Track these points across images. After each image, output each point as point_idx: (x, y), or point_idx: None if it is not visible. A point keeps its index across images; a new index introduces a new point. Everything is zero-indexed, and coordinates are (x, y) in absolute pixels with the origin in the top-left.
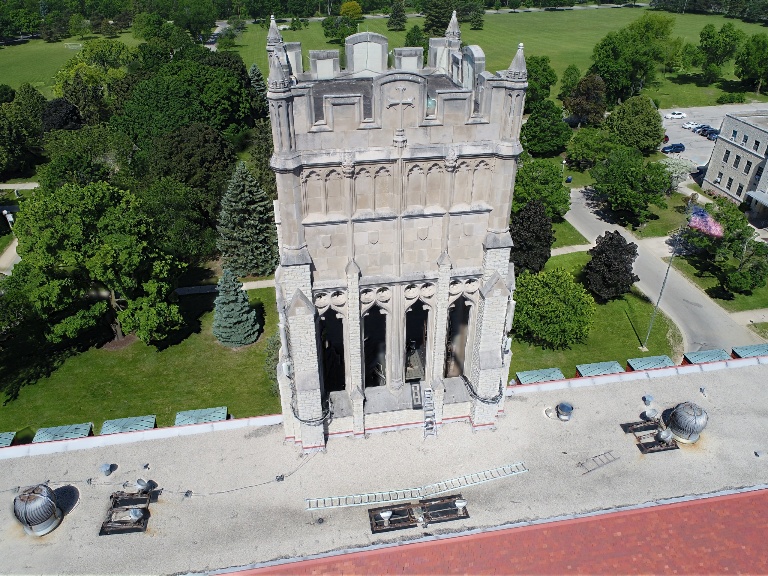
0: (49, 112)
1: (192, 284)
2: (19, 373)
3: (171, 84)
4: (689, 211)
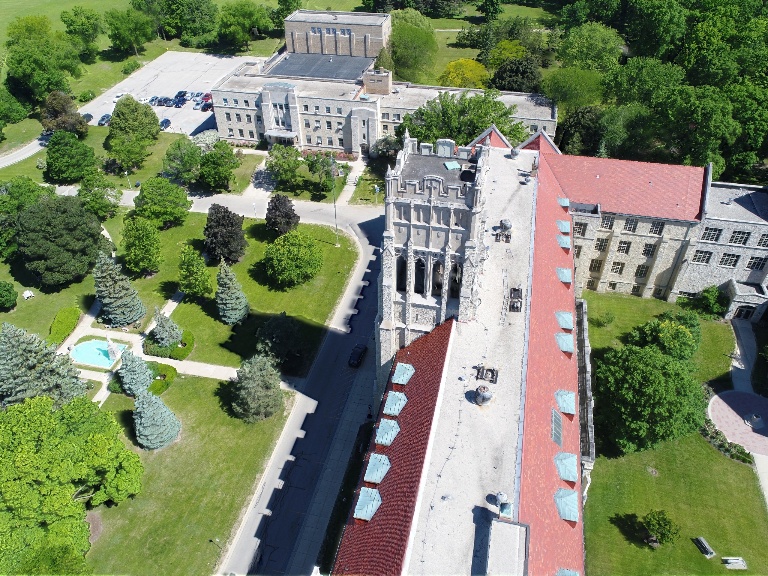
0: None
1: None
2: None
3: None
4: (241, 162)
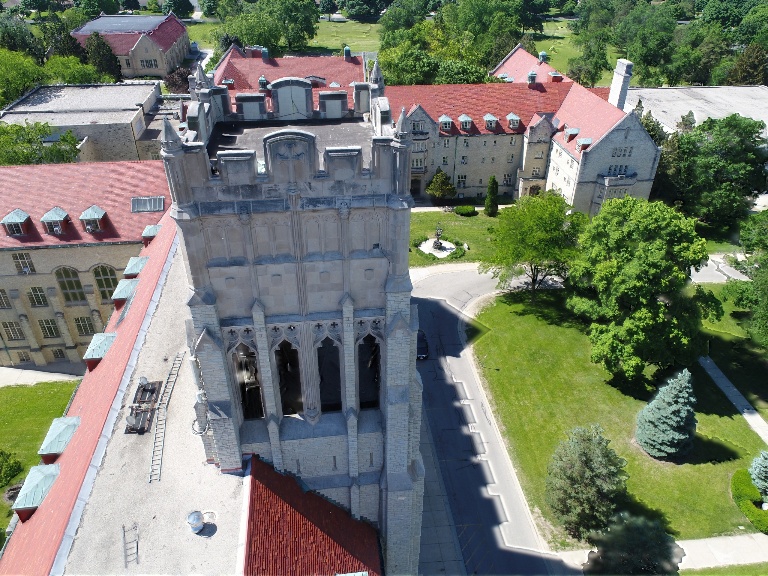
0: None
1: (740, 387)
2: (548, 309)
3: None
4: None
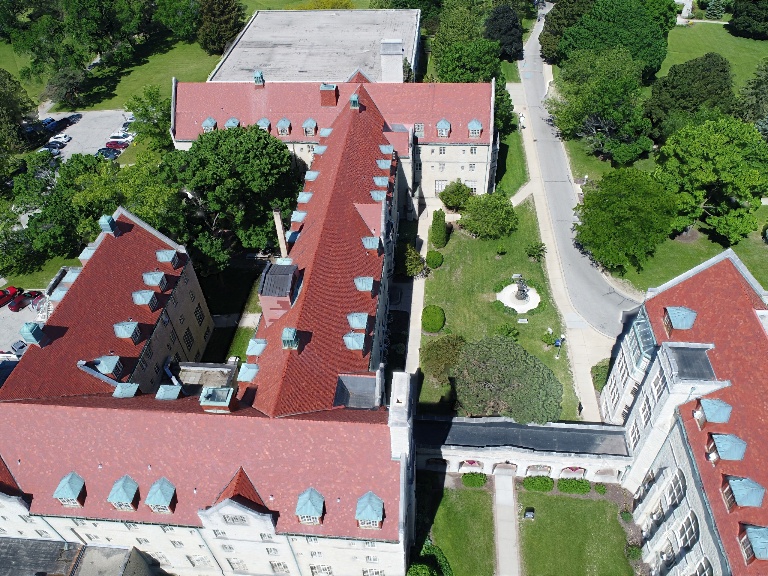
0: (495, 17)
1: None
2: None
3: (631, 1)
4: None
